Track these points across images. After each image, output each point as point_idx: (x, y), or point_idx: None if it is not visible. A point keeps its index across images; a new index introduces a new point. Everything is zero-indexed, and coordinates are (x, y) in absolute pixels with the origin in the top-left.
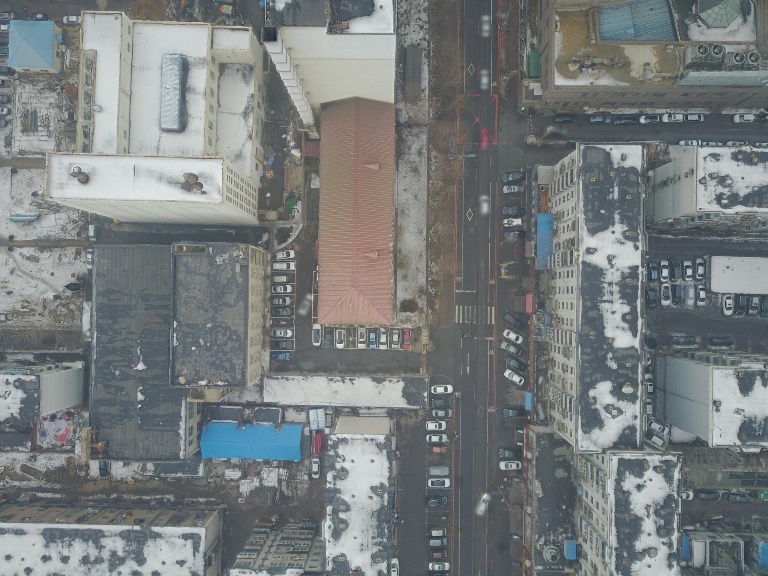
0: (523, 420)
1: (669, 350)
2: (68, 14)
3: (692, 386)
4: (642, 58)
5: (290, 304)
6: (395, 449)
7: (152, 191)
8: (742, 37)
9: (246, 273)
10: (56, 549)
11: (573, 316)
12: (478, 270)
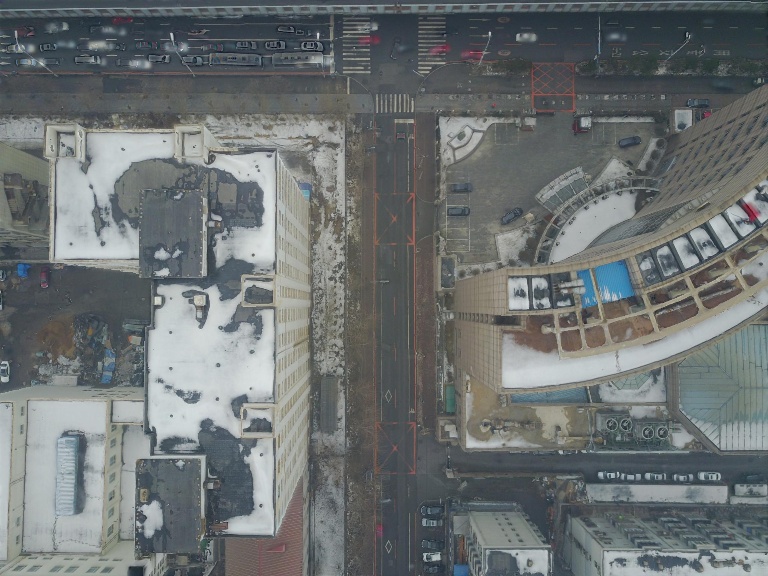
0: None
1: None
2: None
3: None
4: (554, 419)
5: None
6: None
7: None
8: (653, 398)
9: None
10: None
11: None
12: None
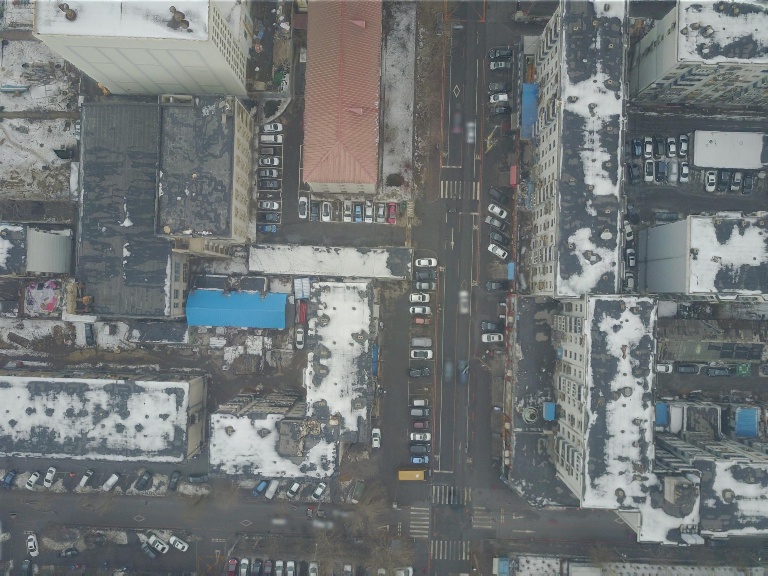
0: (506, 294)
1: (651, 226)
2: None
3: (671, 244)
4: None
5: (277, 177)
6: (379, 321)
7: (139, 28)
8: None
9: (232, 124)
10: (41, 402)
11: (554, 168)
12: (464, 146)
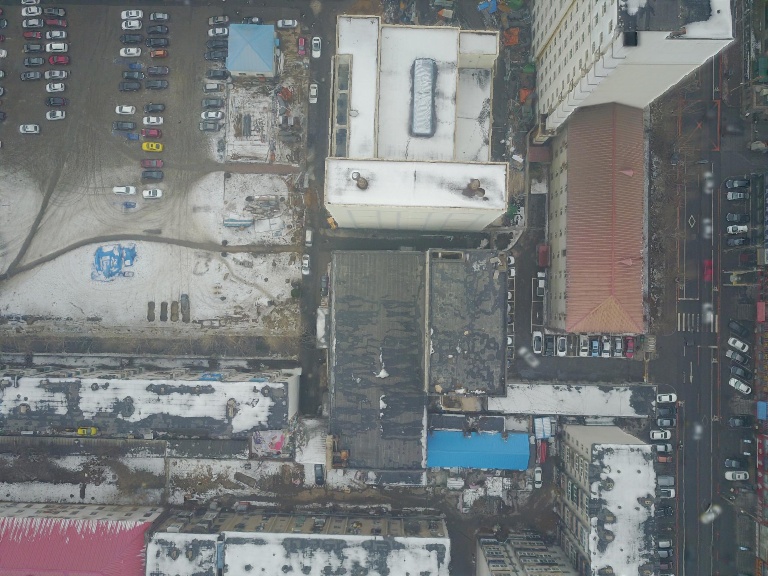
0: (749, 430)
1: None
2: (282, 18)
3: None
4: None
5: (510, 311)
6: None
7: (433, 197)
8: None
9: (504, 280)
10: (297, 559)
11: None
12: (701, 277)
